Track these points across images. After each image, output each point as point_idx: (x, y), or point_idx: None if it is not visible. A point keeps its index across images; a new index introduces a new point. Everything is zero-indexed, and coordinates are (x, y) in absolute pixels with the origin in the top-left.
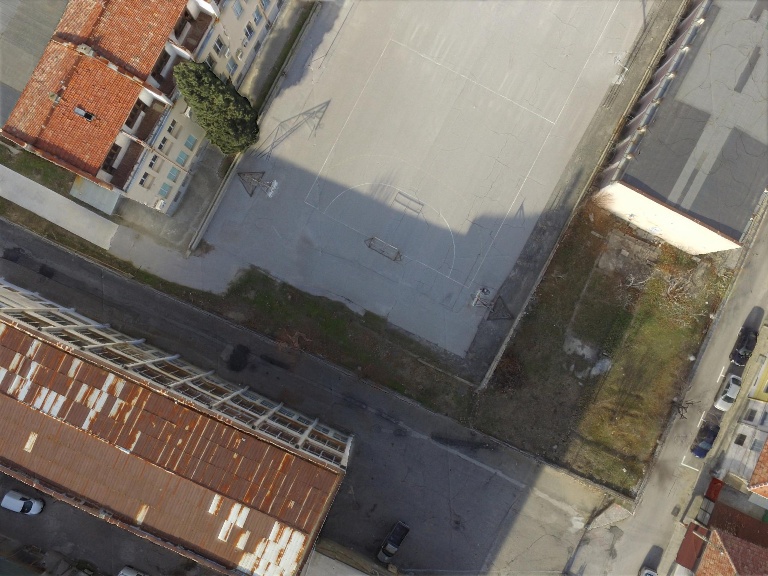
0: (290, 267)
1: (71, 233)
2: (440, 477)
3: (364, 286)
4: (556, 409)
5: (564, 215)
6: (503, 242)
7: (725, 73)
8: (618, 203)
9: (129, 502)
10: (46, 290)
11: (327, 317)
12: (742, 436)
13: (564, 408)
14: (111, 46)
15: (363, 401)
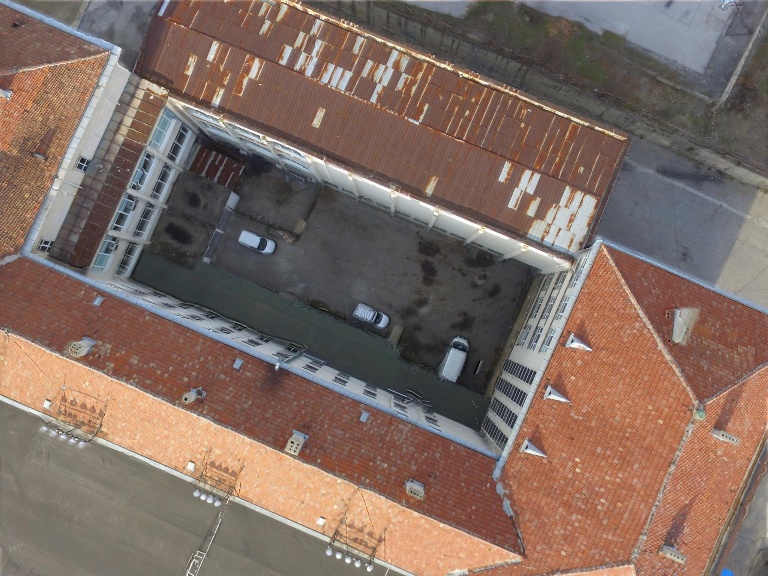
0: None
1: None
2: (667, 210)
3: (602, 5)
4: None
5: None
6: None
7: None
8: None
9: (418, 174)
10: None
11: (565, 38)
12: None
13: None
14: None
15: None
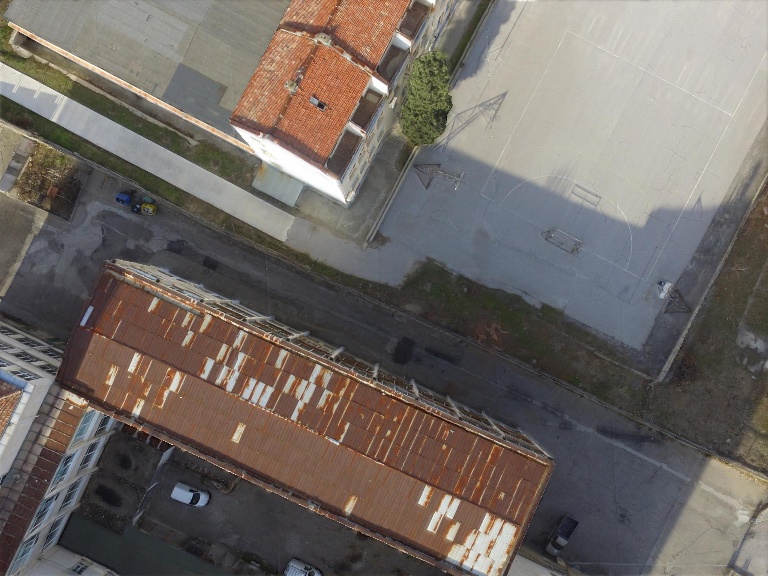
0: (466, 259)
1: (248, 225)
2: (606, 470)
3: (541, 279)
4: (729, 403)
5: (742, 208)
6: (680, 235)
7: None
8: None
9: (337, 493)
10: (210, 282)
11: (503, 310)
12: None
13: (737, 402)
14: (346, 35)
15: (528, 394)
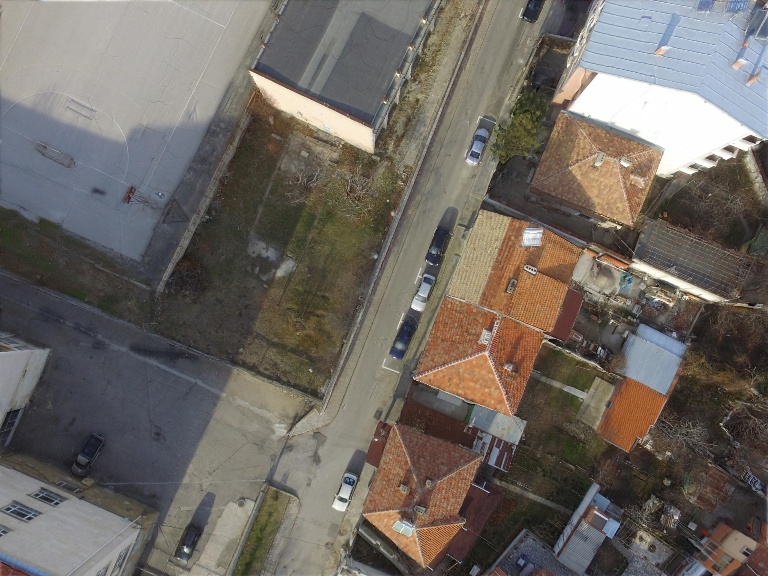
0: None
1: None
2: (139, 389)
3: (39, 194)
4: (241, 312)
5: (237, 117)
6: (177, 145)
7: None
8: (279, 100)
9: None
10: None
11: (3, 226)
12: None
13: (249, 311)
14: None
15: (61, 315)
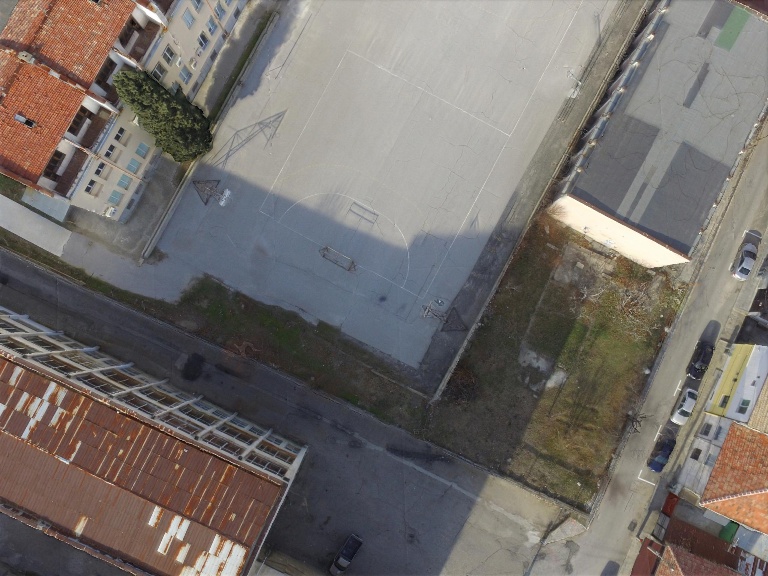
0: (244, 276)
1: (23, 239)
2: (395, 489)
3: (318, 296)
4: (511, 422)
5: (519, 227)
6: (458, 253)
7: (674, 88)
8: (571, 216)
9: (68, 513)
10: None
11: (280, 327)
12: (698, 450)
13: (519, 421)
14: (53, 54)
15: (318, 412)
